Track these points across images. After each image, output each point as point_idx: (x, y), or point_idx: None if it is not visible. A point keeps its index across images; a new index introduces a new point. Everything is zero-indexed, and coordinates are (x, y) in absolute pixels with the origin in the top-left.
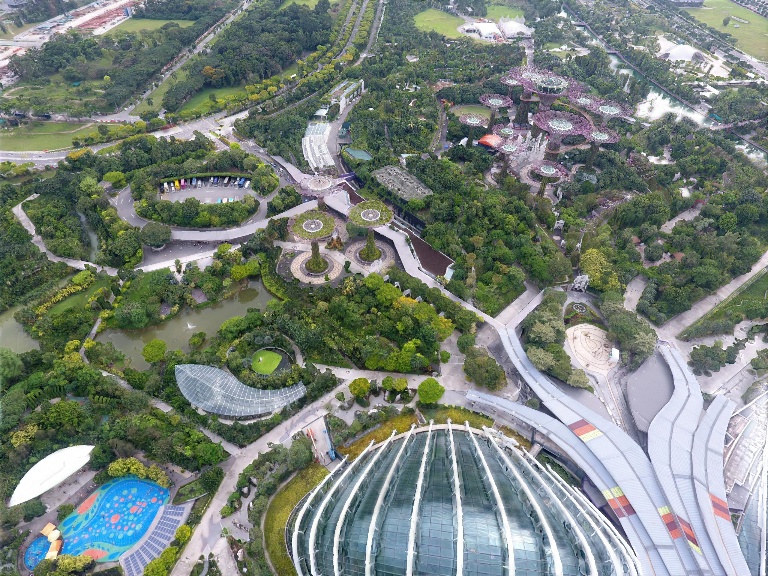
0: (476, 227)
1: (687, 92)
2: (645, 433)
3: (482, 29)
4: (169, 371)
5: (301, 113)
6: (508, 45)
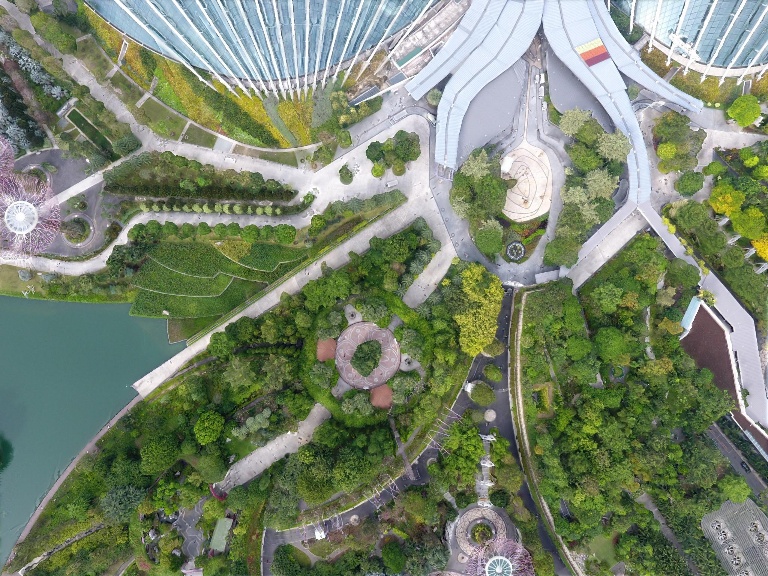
0: (647, 412)
1: None
2: None
3: None
4: None
5: None
6: None
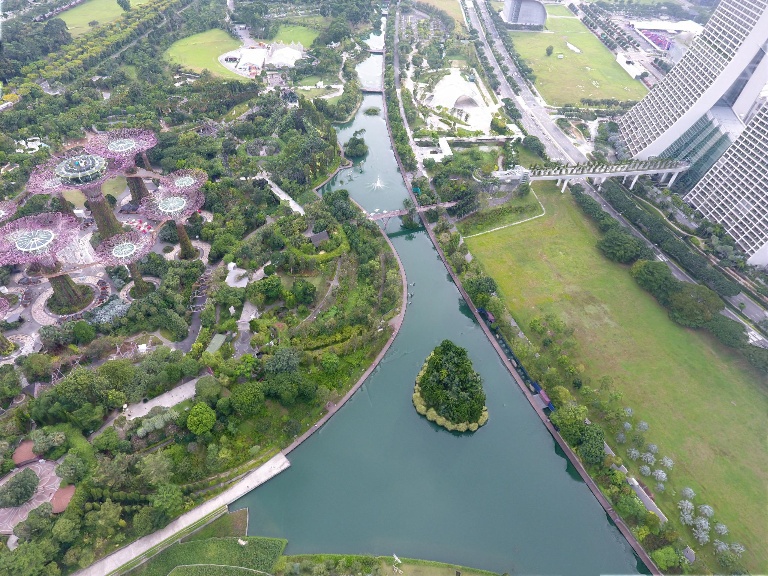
0: None
1: None
2: None
3: (243, 57)
4: None
5: None
6: (235, 82)
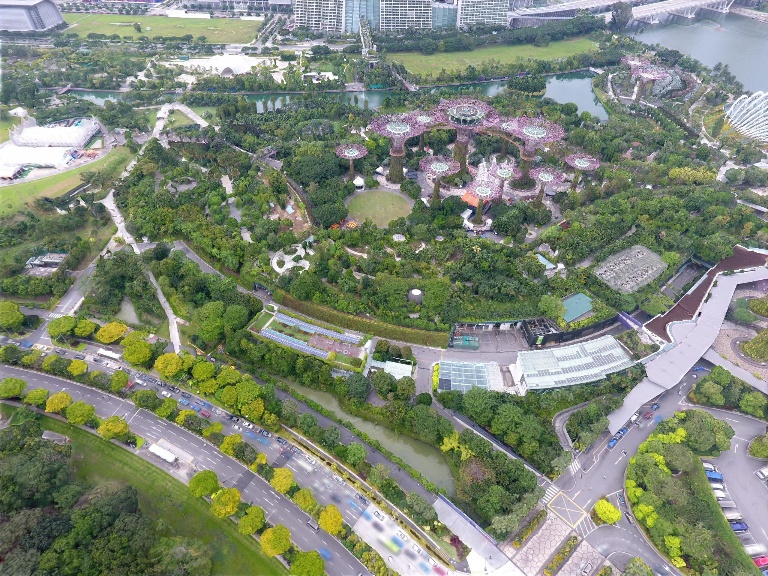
0: None
1: (328, 83)
2: None
3: (30, 160)
4: None
5: (418, 402)
6: (158, 145)
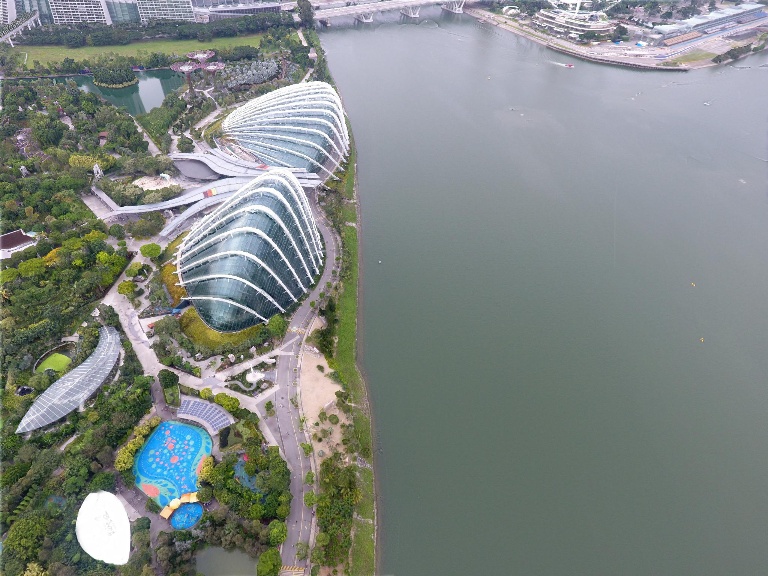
0: None
1: None
2: (219, 178)
3: None
4: (17, 444)
5: None
6: None
